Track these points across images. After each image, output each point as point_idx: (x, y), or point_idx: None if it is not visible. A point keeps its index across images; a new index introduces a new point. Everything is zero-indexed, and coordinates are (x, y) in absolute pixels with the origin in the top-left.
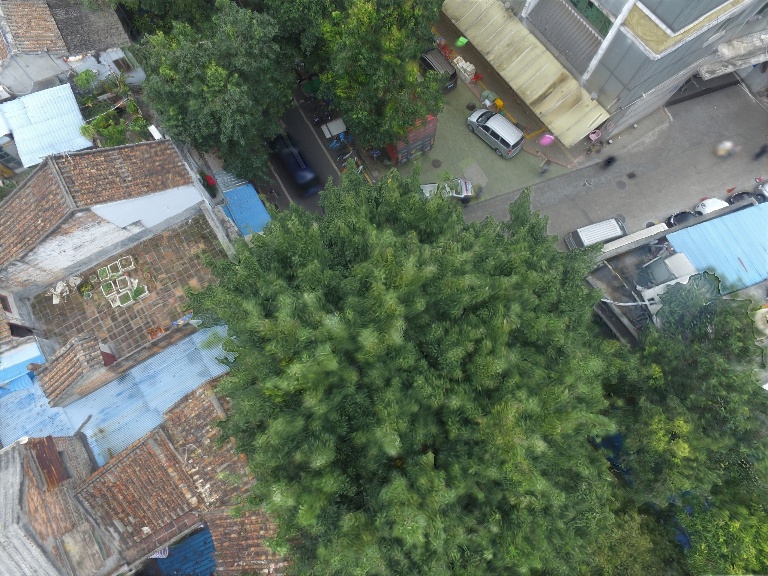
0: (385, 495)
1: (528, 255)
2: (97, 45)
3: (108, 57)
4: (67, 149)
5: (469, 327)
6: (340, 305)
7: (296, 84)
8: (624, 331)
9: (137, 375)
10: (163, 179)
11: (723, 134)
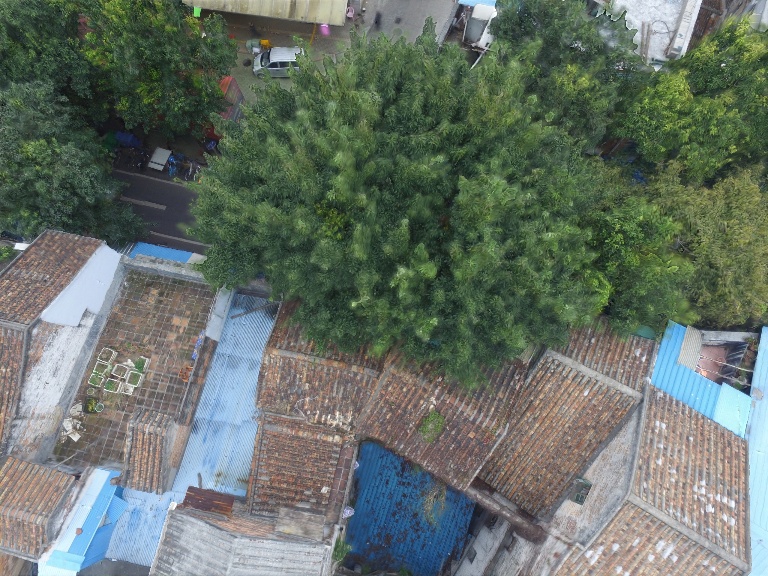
0: (459, 228)
1: None
2: None
3: None
4: None
5: (407, 96)
6: None
7: (100, 137)
8: None
9: (204, 415)
10: (75, 257)
11: None
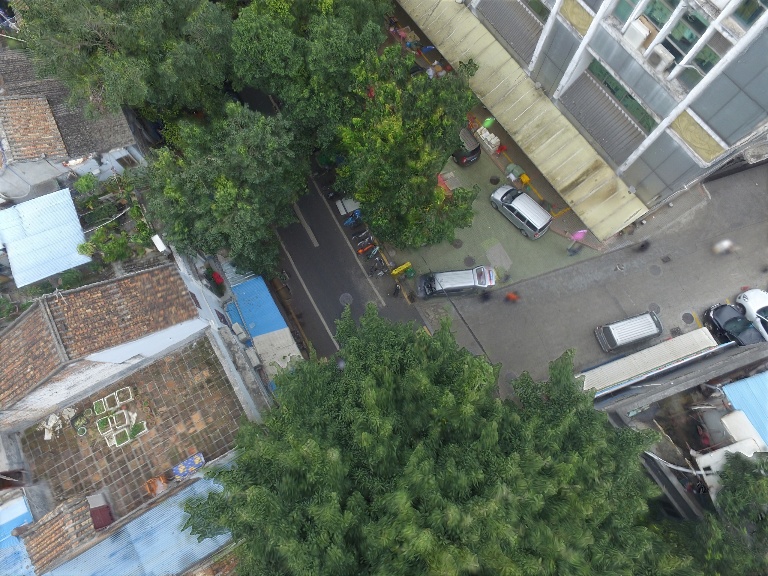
0: None
1: (577, 457)
2: (99, 146)
3: (111, 157)
4: (64, 266)
5: None
6: (362, 548)
7: None
8: (672, 489)
9: (133, 531)
10: (165, 314)
11: (766, 214)
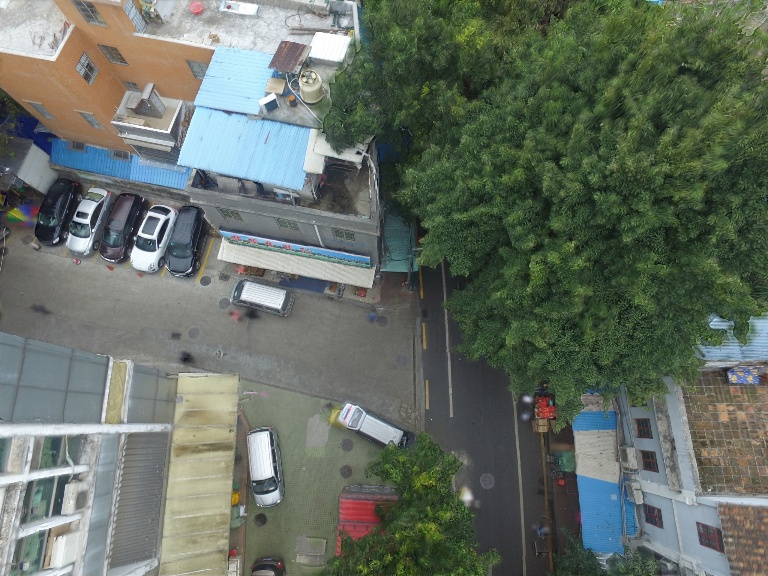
0: (727, 65)
1: (489, 185)
2: None
3: None
4: None
5: (618, 120)
6: None
7: None
8: None
9: None
10: (758, 525)
11: (56, 321)
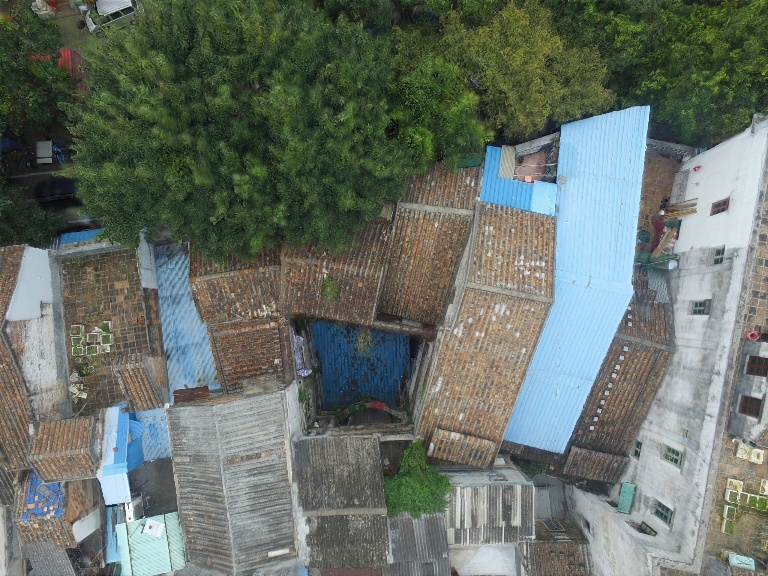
0: (274, 139)
1: None
2: None
3: None
4: None
5: None
6: None
7: None
8: None
9: (170, 345)
10: (10, 265)
11: None
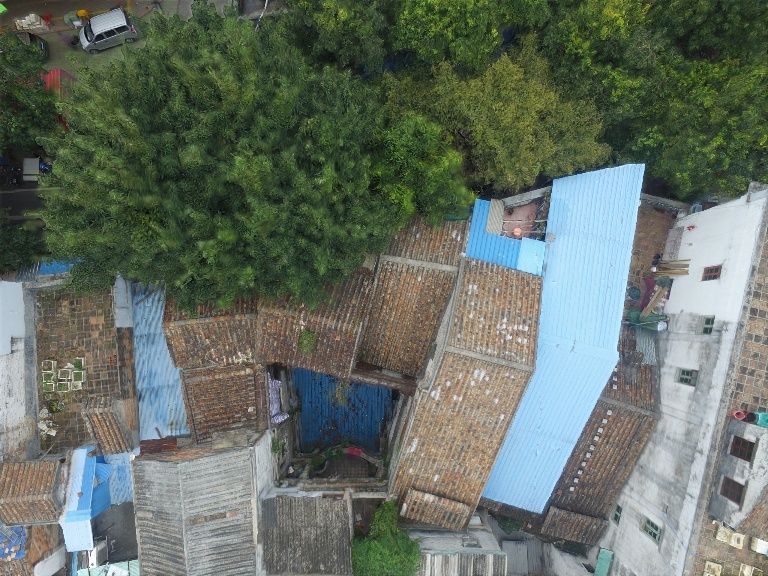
0: (248, 199)
1: None
2: None
3: None
4: None
5: (174, 95)
6: None
7: None
8: None
9: (143, 386)
10: None
11: None
